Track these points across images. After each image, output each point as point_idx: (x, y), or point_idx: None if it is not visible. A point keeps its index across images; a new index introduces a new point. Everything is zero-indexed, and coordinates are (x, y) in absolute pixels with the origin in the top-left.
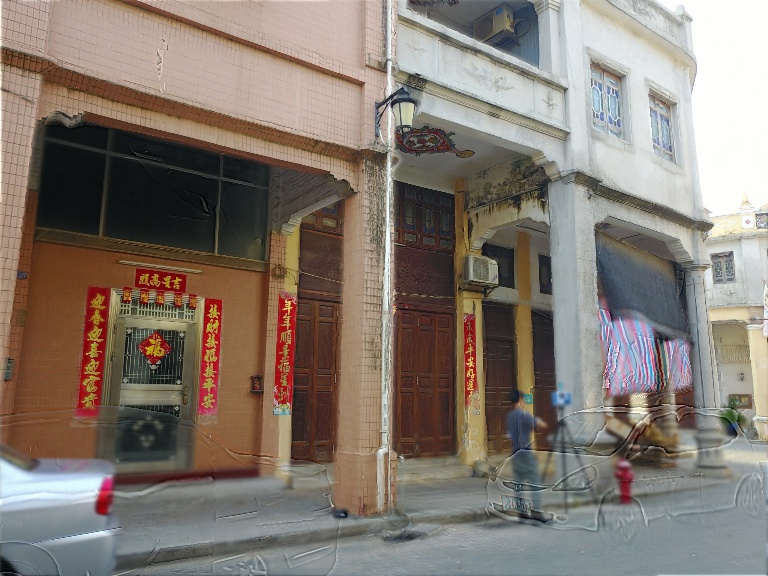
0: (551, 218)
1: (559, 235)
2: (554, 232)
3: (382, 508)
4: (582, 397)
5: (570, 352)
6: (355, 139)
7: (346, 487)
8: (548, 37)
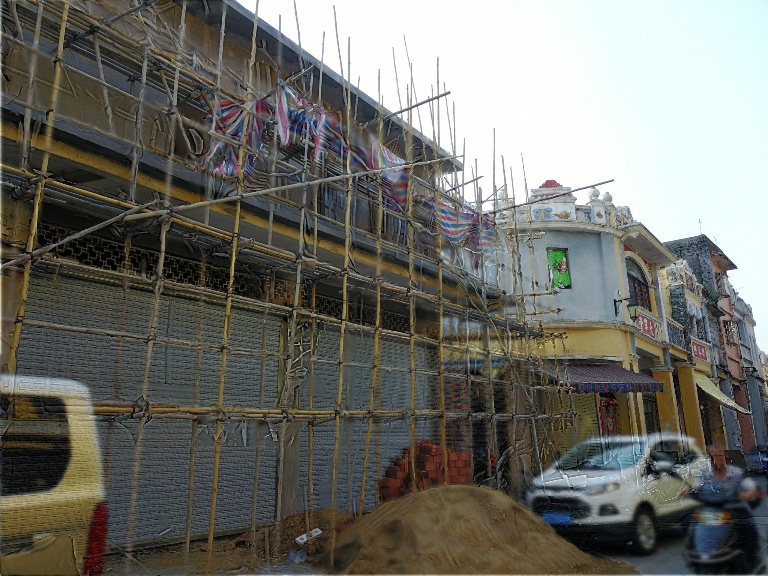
0: (748, 386)
1: (752, 392)
2: (750, 391)
3: (759, 465)
4: (766, 438)
5: (760, 426)
6: (740, 377)
7: (751, 460)
8: (743, 332)
